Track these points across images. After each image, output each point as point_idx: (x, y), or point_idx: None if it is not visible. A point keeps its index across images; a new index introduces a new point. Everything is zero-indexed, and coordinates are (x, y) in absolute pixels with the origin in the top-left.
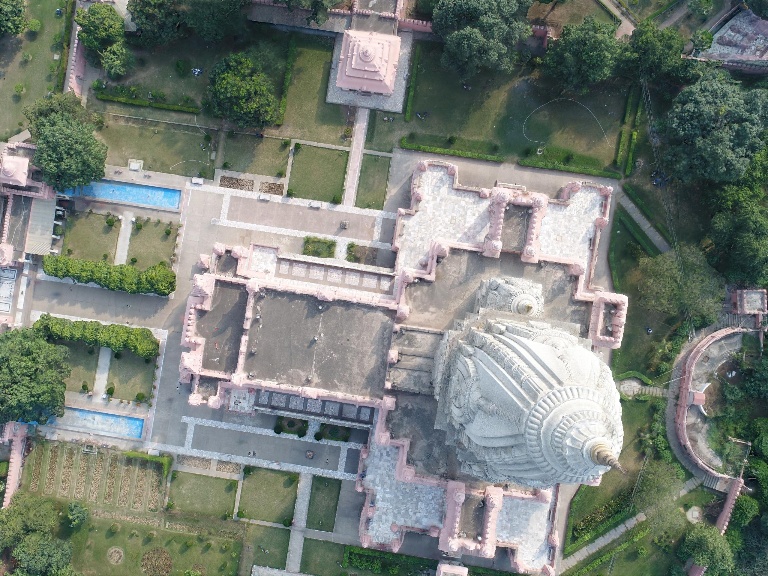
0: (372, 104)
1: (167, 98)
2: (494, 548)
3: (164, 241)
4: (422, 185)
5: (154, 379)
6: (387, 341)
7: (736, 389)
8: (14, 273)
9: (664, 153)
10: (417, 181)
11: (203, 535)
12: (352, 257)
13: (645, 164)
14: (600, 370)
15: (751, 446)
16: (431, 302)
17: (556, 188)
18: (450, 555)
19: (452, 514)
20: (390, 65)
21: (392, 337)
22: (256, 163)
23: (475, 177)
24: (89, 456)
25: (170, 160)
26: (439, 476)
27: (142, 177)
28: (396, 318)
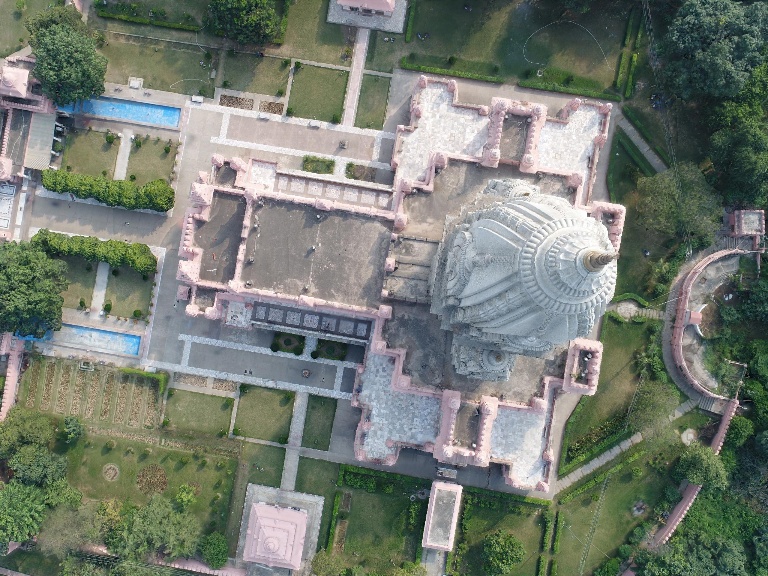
0: (373, 24)
1: (168, 16)
2: (489, 457)
3: (163, 159)
4: (422, 102)
5: (151, 296)
6: (384, 251)
7: (733, 310)
8: (13, 189)
9: (664, 70)
10: (417, 97)
11: (198, 452)
12: (351, 177)
13: (645, 87)
14: (595, 221)
15: (747, 368)
16: (429, 213)
17: (556, 110)
18: (445, 475)
19: (447, 422)
20: None
21: (389, 246)
22: (256, 82)
23: (475, 98)
24: (86, 373)
25: (170, 78)
26: (435, 386)
27: (142, 95)
28: (394, 229)
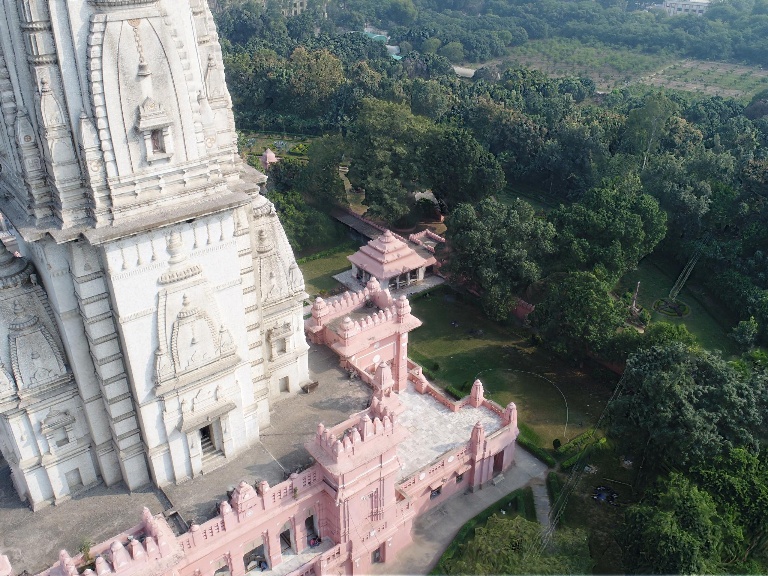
0: None
1: None
2: None
3: None
4: None
5: None
6: None
7: None
8: None
9: None
10: None
11: None
12: None
13: (597, 474)
14: None
15: None
16: None
17: None
18: None
19: None
20: (400, 263)
21: None
22: None
23: None
24: None
25: None
26: None
27: None
28: None
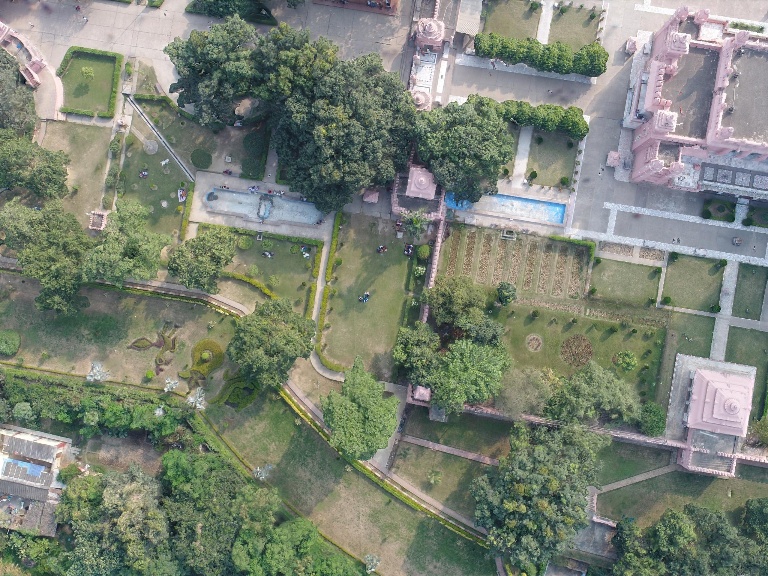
0: None
1: None
2: None
3: (586, 27)
4: None
5: (578, 163)
6: None
7: None
8: (434, 57)
9: None
10: None
11: (629, 321)
12: None
13: None
14: None
15: None
16: None
17: None
18: None
19: None
20: None
21: None
22: None
23: None
24: (507, 242)
25: None
26: None
27: None
28: None
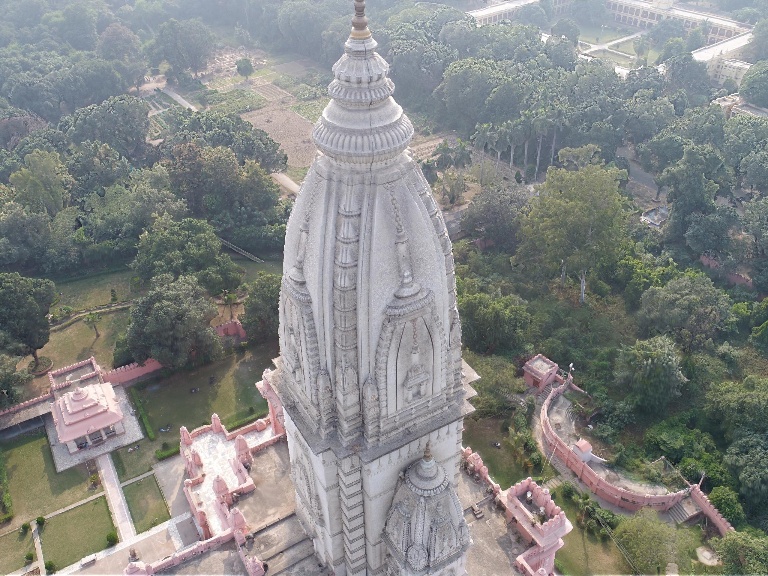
0: (109, 448)
1: None
2: None
3: None
4: None
5: None
6: (242, 574)
7: (602, 426)
8: None
9: None
10: (187, 452)
11: None
12: None
13: None
14: None
15: (666, 460)
16: (265, 506)
17: None
18: None
19: None
20: (109, 400)
21: None
22: None
23: None
24: None
25: None
26: None
27: None
28: (237, 546)
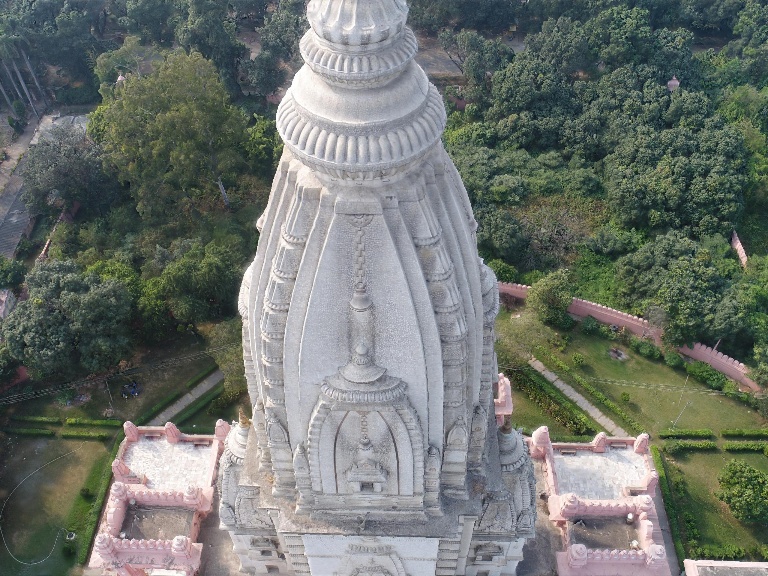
0: None
1: None
2: None
3: None
4: None
5: None
6: None
7: None
8: None
9: None
10: None
11: None
12: None
13: None
14: None
15: None
16: None
17: None
18: None
19: (610, 567)
20: None
21: None
22: None
23: None
24: None
25: None
26: None
27: None
28: None
